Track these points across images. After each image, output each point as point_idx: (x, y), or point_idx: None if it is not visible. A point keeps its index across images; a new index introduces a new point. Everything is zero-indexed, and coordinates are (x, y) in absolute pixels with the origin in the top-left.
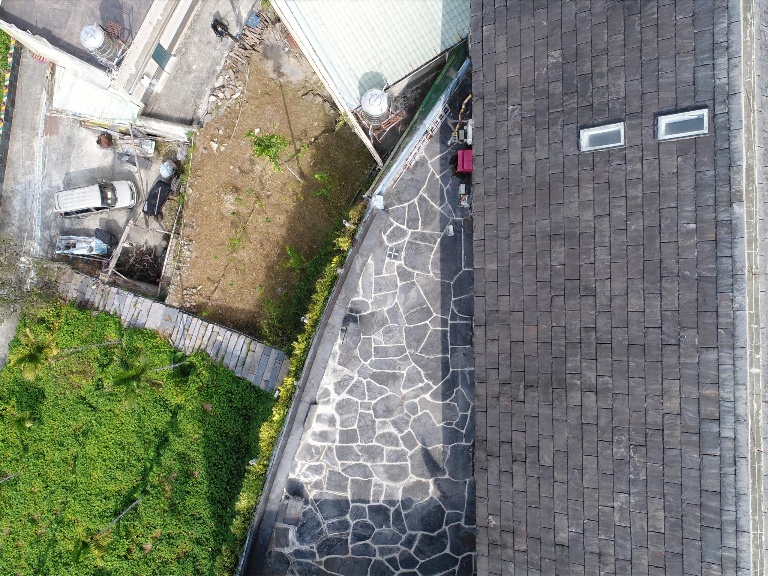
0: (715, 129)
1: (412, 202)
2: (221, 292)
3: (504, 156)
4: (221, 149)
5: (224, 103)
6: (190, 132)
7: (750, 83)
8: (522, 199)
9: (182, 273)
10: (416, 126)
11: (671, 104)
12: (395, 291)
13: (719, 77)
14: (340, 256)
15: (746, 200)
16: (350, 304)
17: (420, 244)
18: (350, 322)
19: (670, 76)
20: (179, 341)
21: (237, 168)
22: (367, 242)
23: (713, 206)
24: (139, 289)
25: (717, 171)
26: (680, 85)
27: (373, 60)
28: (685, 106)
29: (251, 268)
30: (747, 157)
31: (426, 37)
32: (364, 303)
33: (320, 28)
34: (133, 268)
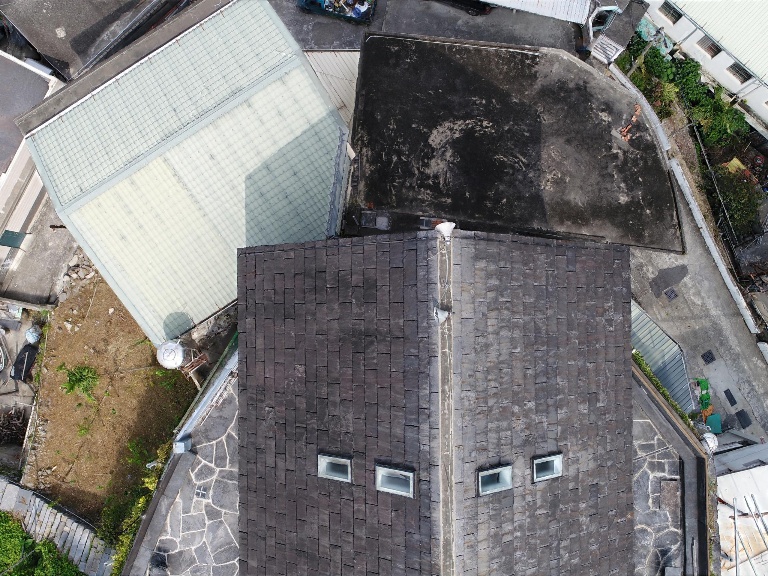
0: (420, 494)
1: (220, 440)
2: (74, 474)
3: (262, 456)
4: (75, 329)
5: (78, 283)
6: (45, 311)
7: (448, 456)
8: (275, 505)
9: (37, 453)
10: (226, 361)
11: (387, 455)
12: (203, 530)
13: (423, 443)
14: (147, 496)
15: (443, 575)
16: (158, 543)
17: (228, 482)
18: (153, 567)
19: (386, 427)
20: (31, 526)
21: (91, 348)
22: (173, 483)
23: (418, 571)
24: (1, 461)
25: (421, 538)
26: (393, 439)
27: (177, 301)
28: (397, 462)
29: (103, 451)
30: (444, 532)
31: (231, 277)
32: (172, 542)
33: (120, 274)
34: (1, 432)
